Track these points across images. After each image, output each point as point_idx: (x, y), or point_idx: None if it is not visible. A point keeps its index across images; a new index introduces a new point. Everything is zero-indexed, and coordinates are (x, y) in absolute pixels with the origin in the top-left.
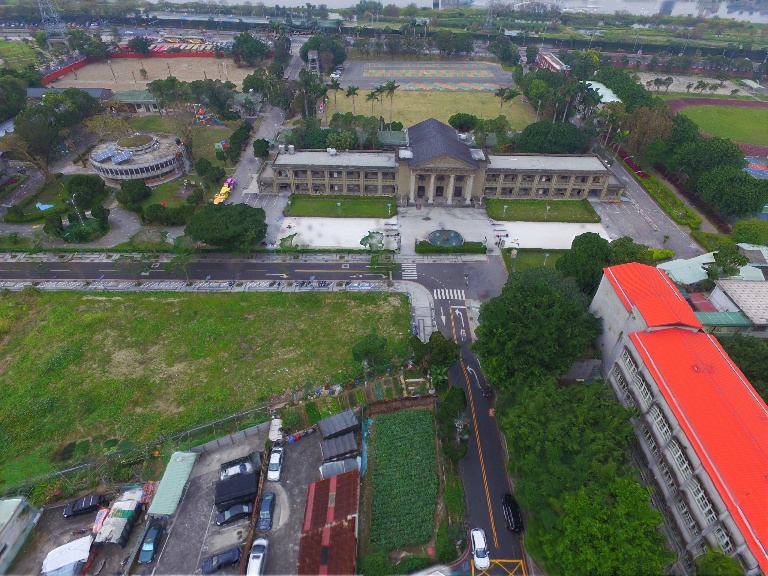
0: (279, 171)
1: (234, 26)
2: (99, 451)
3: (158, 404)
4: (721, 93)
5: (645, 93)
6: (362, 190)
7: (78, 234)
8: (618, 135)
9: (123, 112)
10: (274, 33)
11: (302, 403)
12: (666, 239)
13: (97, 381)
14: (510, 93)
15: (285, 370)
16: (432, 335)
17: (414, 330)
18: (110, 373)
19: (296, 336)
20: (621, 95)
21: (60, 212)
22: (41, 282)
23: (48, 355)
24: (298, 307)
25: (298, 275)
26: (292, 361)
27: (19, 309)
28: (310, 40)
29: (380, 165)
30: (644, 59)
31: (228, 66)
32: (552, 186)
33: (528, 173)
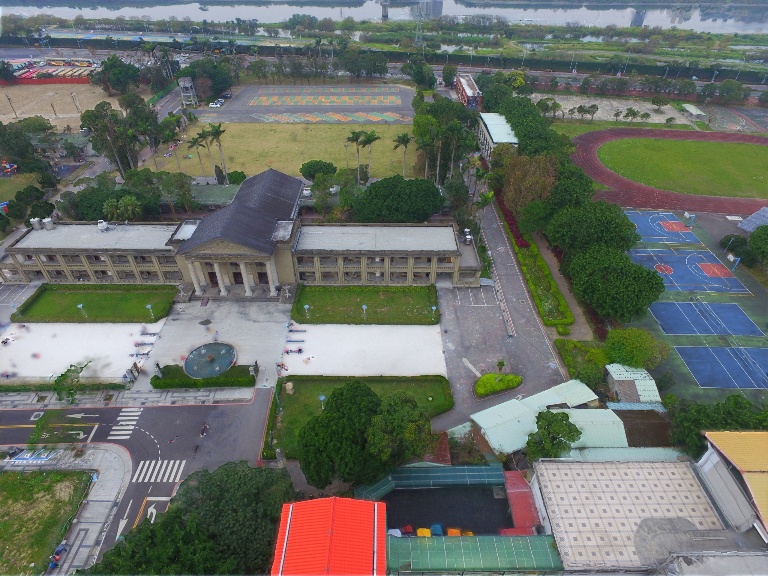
0: None
1: (135, 45)
2: None
3: None
4: (656, 121)
5: (542, 132)
6: (138, 277)
7: None
8: (481, 197)
9: None
10: (146, 57)
11: None
12: (501, 366)
13: None
14: (365, 137)
15: None
16: None
17: (52, 560)
18: None
19: None
20: (518, 133)
21: None
22: None
23: None
24: None
25: None
26: None
27: None
28: None
29: (156, 246)
30: (576, 80)
31: (99, 94)
32: (386, 269)
33: (349, 255)
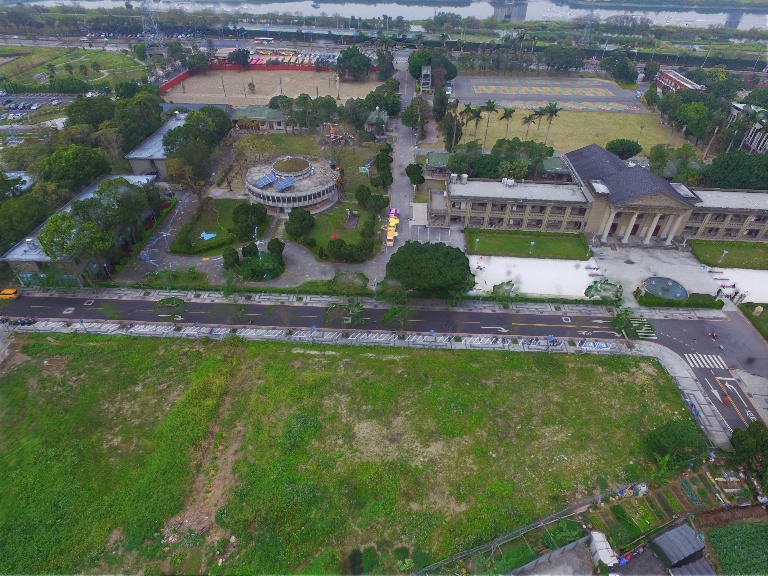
0: (453, 202)
1: (322, 38)
2: (392, 564)
3: (434, 499)
4: None
5: None
6: (544, 226)
7: (262, 272)
8: None
9: (246, 129)
10: (383, 47)
11: (605, 506)
12: None
13: (351, 463)
14: (685, 118)
15: (563, 458)
16: (753, 427)
17: (693, 409)
18: (361, 453)
19: (555, 411)
20: None
21: (226, 243)
22: (238, 328)
23: (283, 425)
24: (539, 372)
25: (518, 329)
26: (566, 446)
27: (229, 363)
28: (419, 54)
29: (568, 199)
30: None
31: (331, 80)
32: (765, 227)
33: (741, 213)
